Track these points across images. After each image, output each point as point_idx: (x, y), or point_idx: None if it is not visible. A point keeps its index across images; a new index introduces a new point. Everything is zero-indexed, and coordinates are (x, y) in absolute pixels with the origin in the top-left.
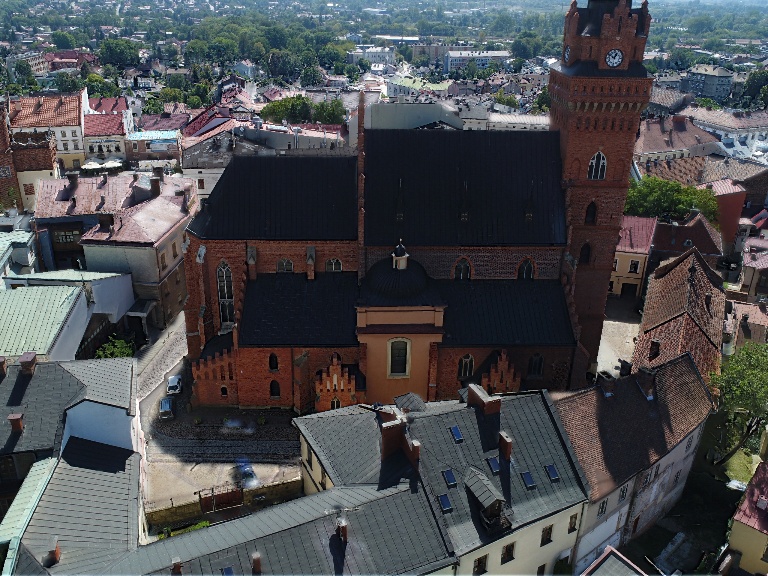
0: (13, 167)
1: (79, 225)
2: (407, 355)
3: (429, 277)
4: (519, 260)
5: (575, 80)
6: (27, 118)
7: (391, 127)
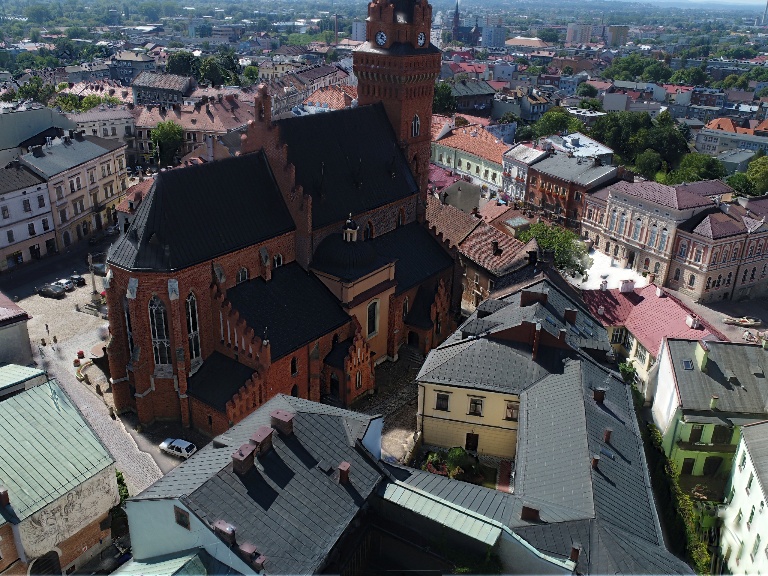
0: None
1: None
2: (377, 314)
3: None
4: (397, 212)
5: (406, 58)
6: None
7: (1, 142)
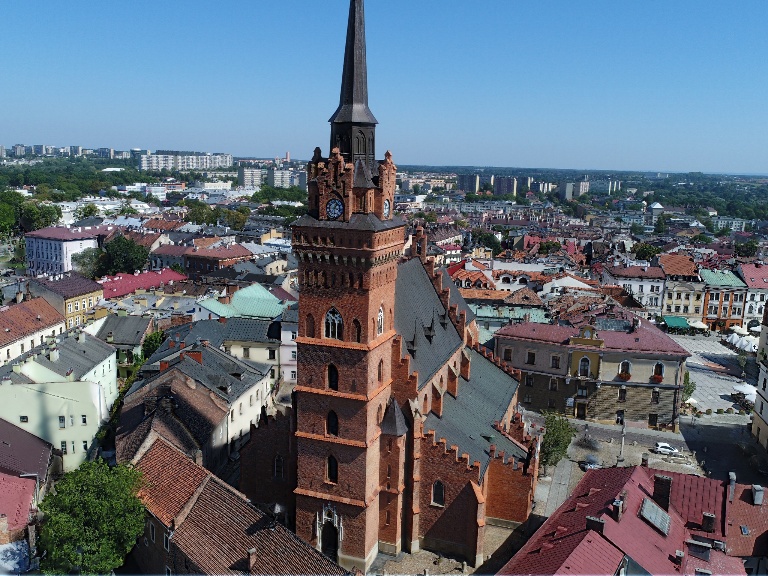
0: None
1: None
2: None
3: None
4: None
5: None
6: None
7: None
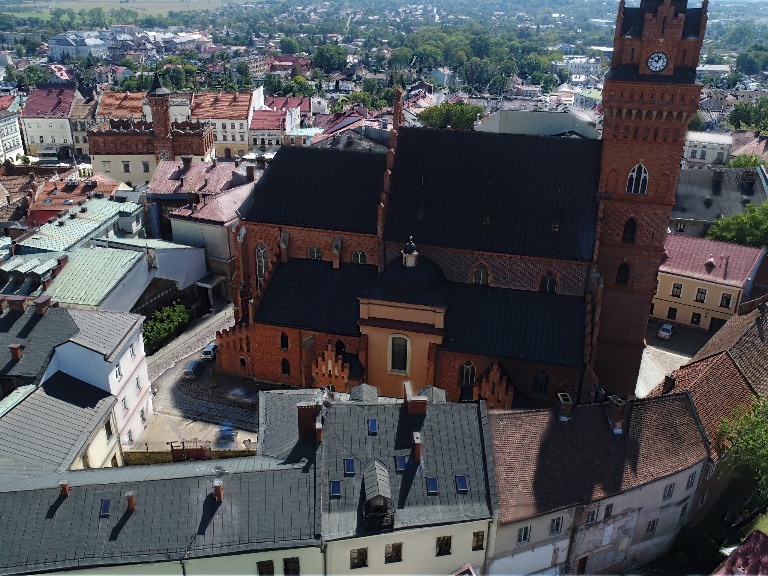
0: (171, 151)
1: (183, 202)
2: (407, 352)
3: (446, 279)
4: (540, 272)
5: (611, 84)
6: (205, 110)
7: None
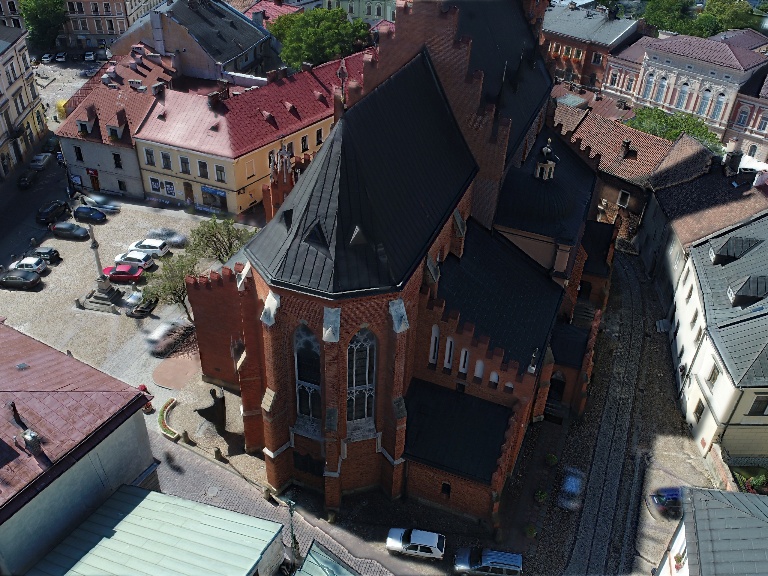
0: None
1: None
2: None
3: None
4: None
5: None
6: None
7: None
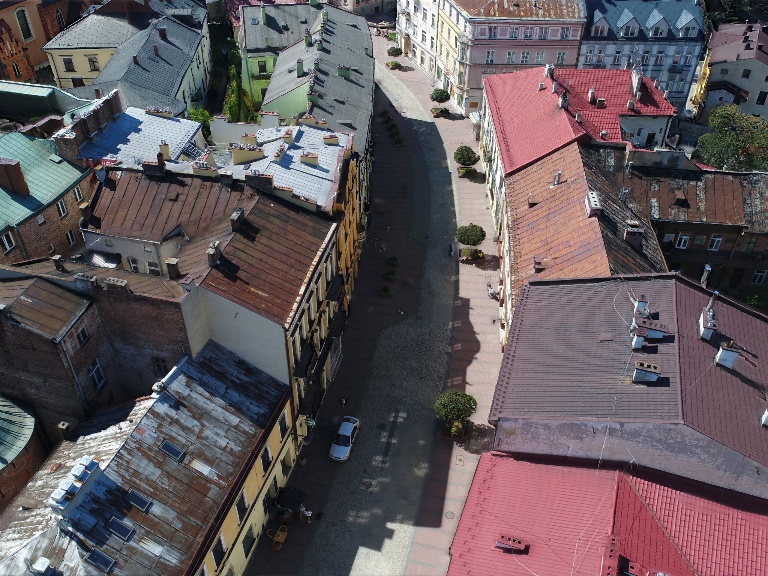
0: None
1: None
2: (28, 21)
3: None
4: None
5: None
6: None
7: None
